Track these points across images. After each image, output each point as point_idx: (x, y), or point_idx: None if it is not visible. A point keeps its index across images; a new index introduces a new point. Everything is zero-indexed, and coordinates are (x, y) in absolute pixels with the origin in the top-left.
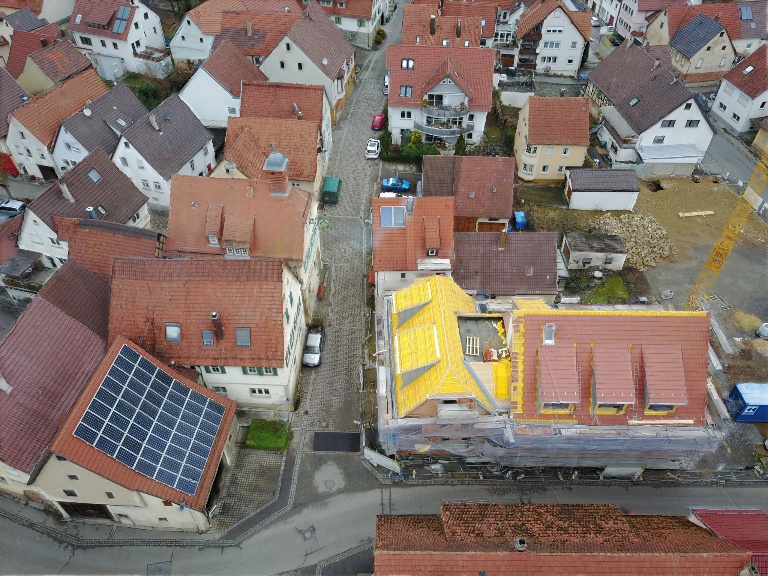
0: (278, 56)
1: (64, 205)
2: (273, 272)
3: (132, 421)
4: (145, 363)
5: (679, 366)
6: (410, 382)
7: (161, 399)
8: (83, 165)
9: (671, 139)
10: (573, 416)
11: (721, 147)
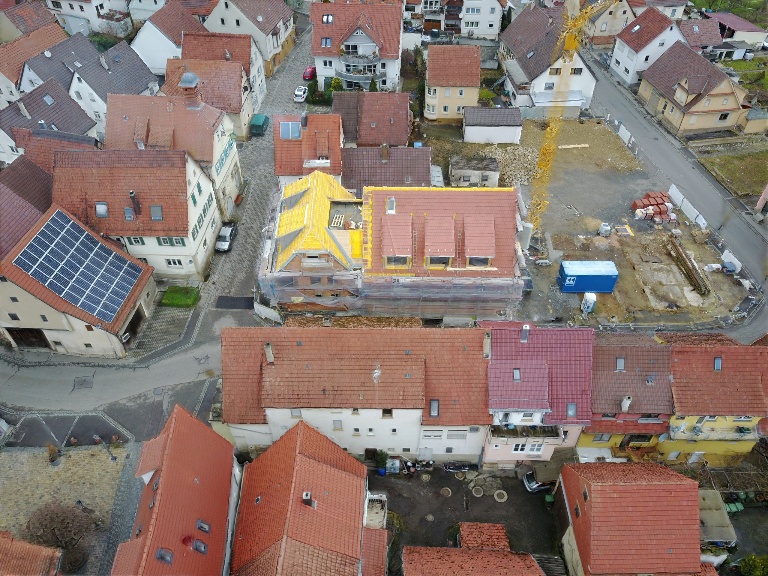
0: (219, 14)
1: (22, 120)
2: (178, 160)
3: (62, 264)
4: (76, 227)
5: (491, 229)
6: (286, 246)
7: (88, 254)
8: (39, 90)
9: (560, 86)
10: (411, 270)
11: (611, 96)
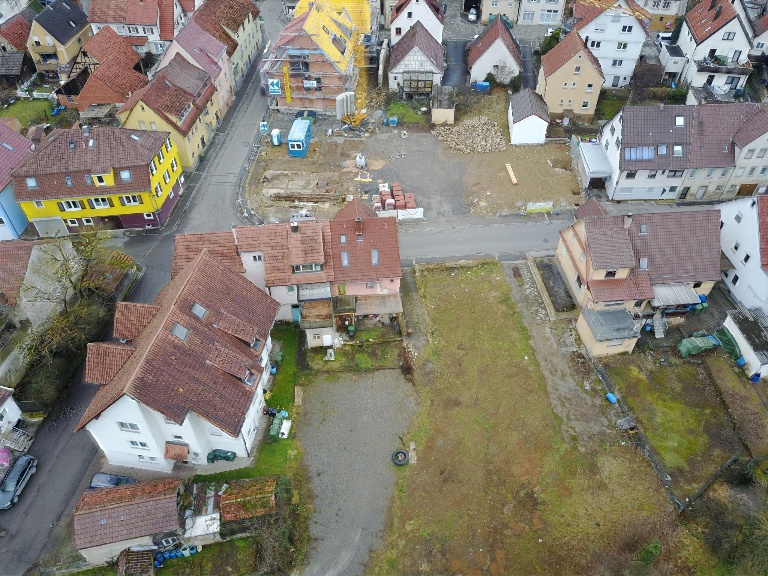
0: None
1: None
2: None
3: None
4: None
5: None
6: None
7: None
8: None
9: None
10: None
11: None
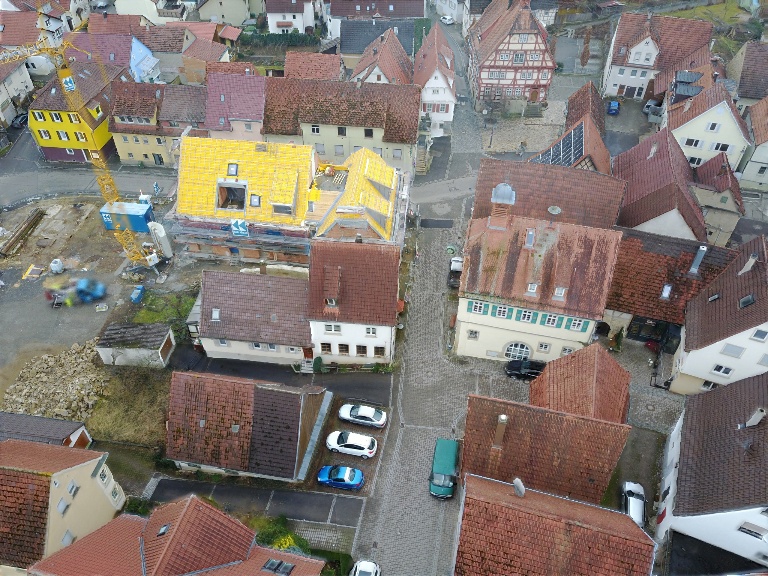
0: None
1: (742, 265)
2: None
3: None
4: None
5: None
6: None
7: None
8: (764, 293)
9: None
10: None
11: None
